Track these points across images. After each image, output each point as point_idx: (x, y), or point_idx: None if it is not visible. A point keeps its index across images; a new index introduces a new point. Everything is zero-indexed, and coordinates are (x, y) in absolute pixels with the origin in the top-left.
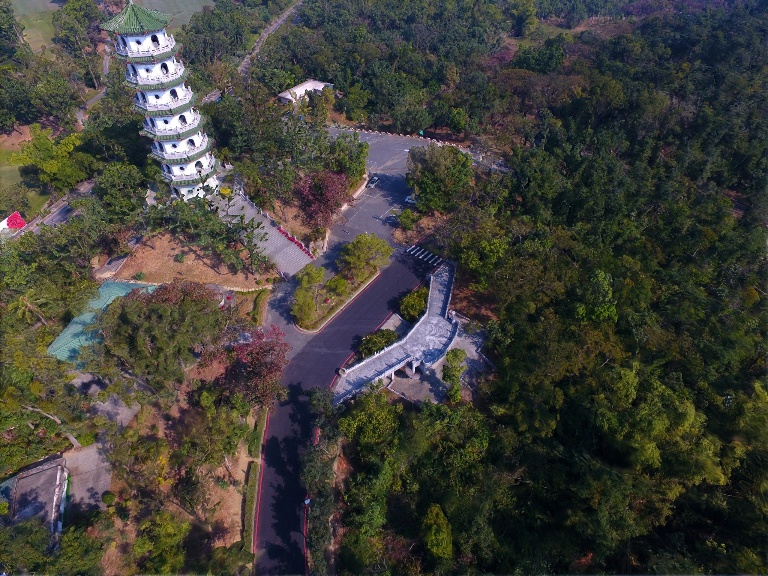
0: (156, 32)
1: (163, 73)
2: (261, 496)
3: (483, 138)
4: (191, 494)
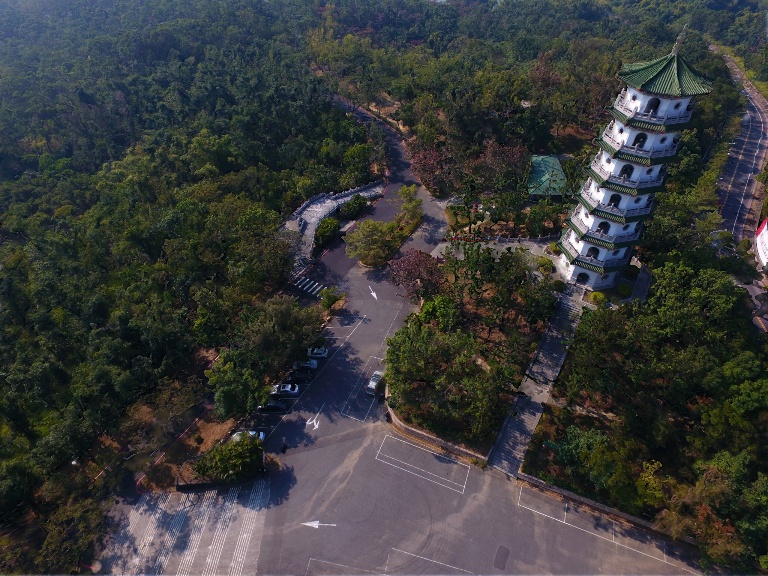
0: None
1: None
2: None
3: None
4: None
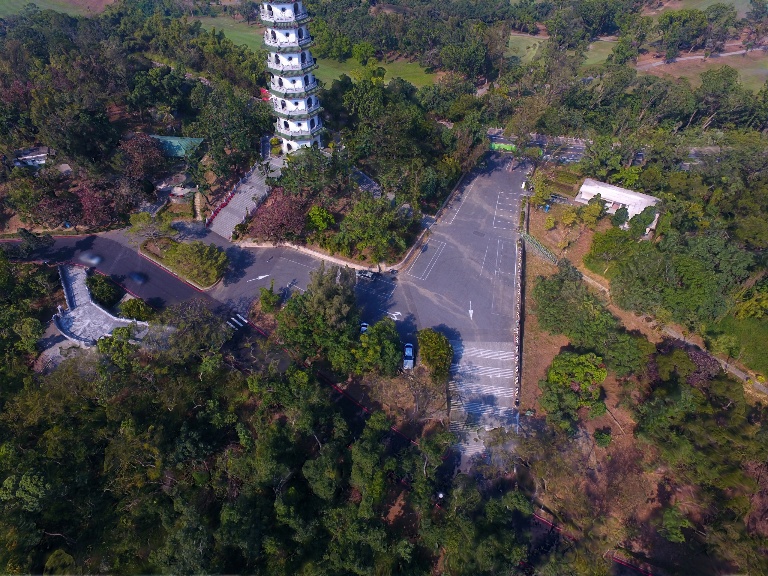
0: (271, 3)
1: (272, 38)
2: (15, 241)
3: (580, 442)
4: (7, 200)
